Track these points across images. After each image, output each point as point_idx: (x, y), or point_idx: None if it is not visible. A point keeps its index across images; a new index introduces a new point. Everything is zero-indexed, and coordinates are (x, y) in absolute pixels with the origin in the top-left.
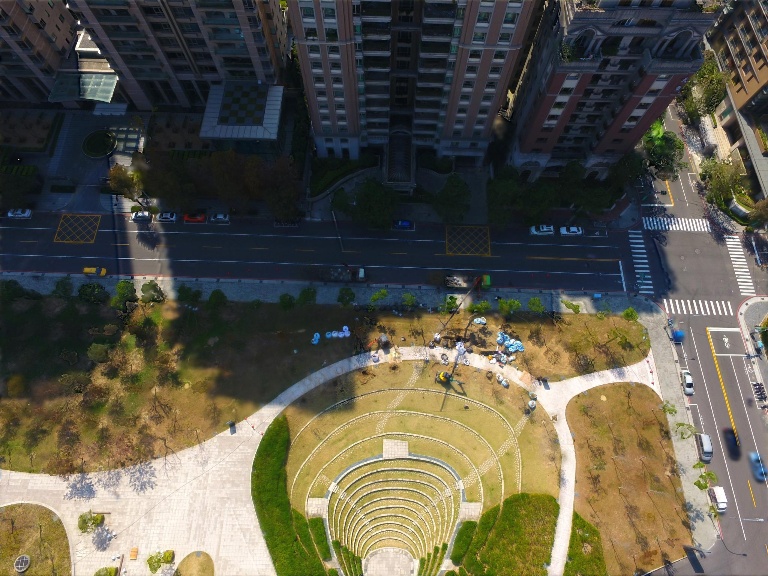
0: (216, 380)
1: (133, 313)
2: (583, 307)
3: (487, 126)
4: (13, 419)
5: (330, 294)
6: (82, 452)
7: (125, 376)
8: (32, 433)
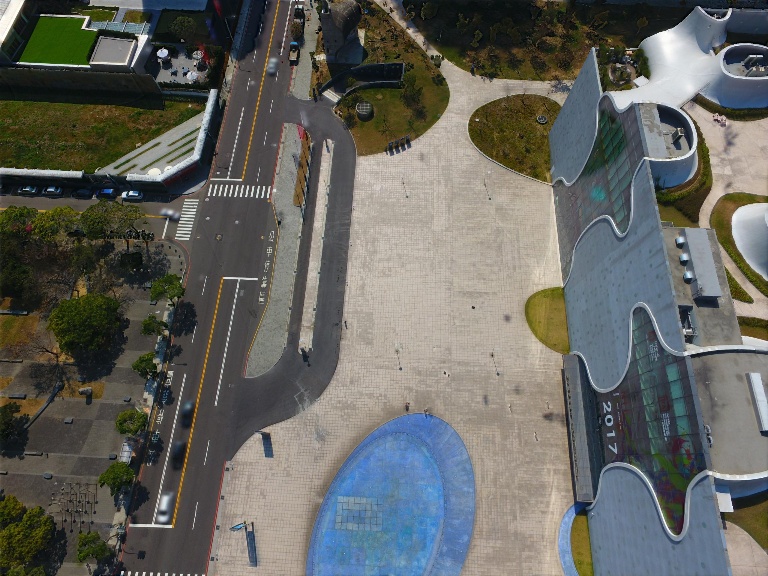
0: (629, 38)
1: (546, 8)
2: None
3: None
4: (493, 55)
5: None
6: (553, 70)
7: (562, 35)
8: (511, 61)
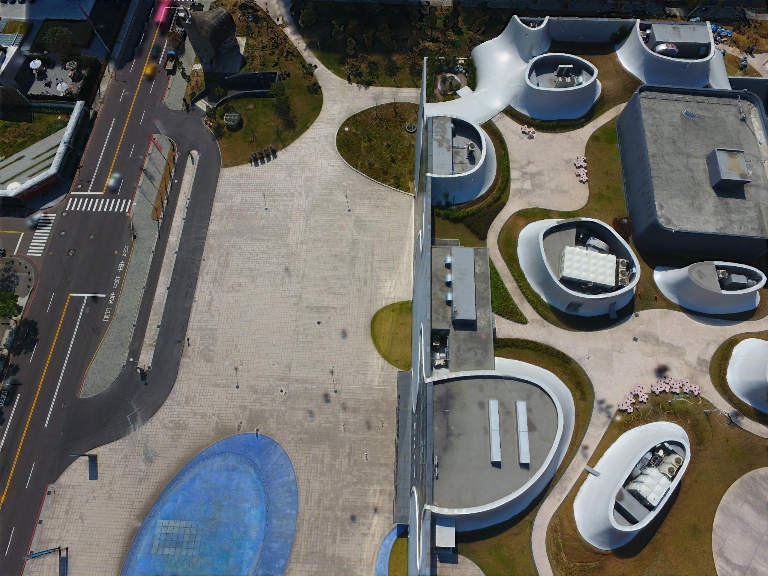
0: None
1: (435, 13)
2: None
3: None
4: (372, 62)
5: (578, 5)
6: None
7: (445, 41)
8: (390, 68)
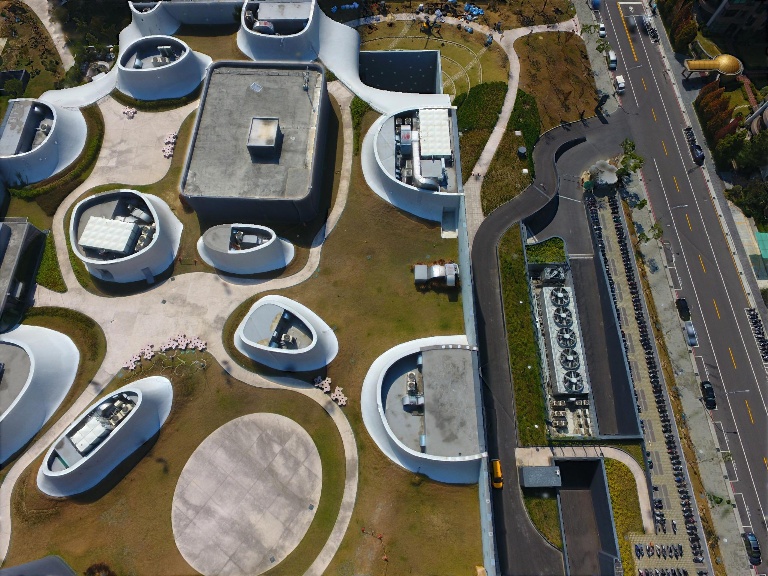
0: None
1: None
2: None
3: None
4: None
5: None
6: None
7: None
8: None
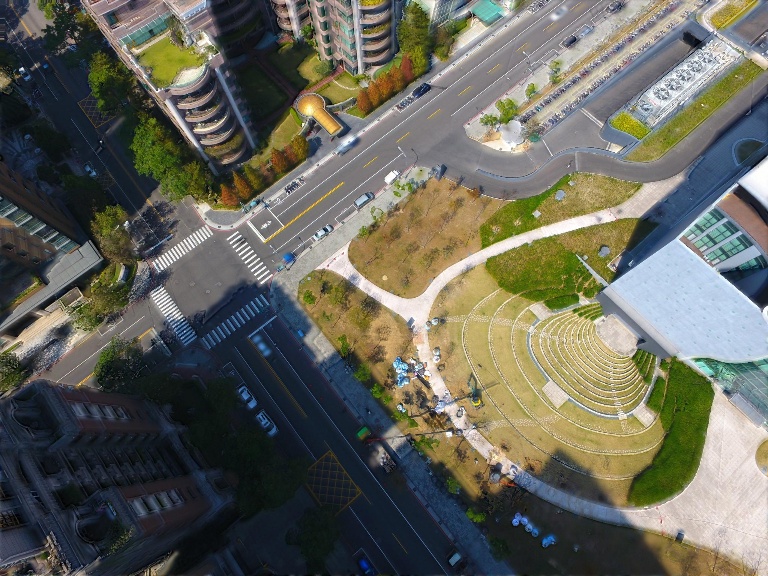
0: None
1: None
2: (318, 338)
3: (205, 571)
4: None
5: (495, 572)
6: None
7: None
8: None
